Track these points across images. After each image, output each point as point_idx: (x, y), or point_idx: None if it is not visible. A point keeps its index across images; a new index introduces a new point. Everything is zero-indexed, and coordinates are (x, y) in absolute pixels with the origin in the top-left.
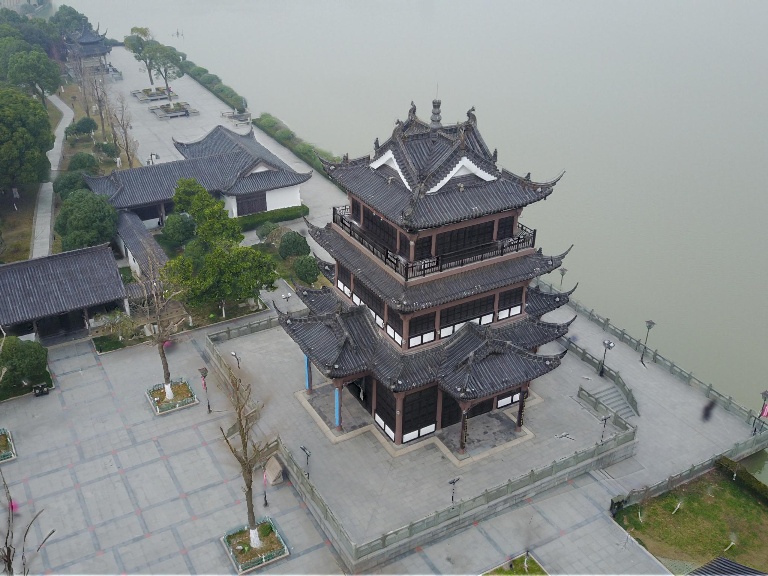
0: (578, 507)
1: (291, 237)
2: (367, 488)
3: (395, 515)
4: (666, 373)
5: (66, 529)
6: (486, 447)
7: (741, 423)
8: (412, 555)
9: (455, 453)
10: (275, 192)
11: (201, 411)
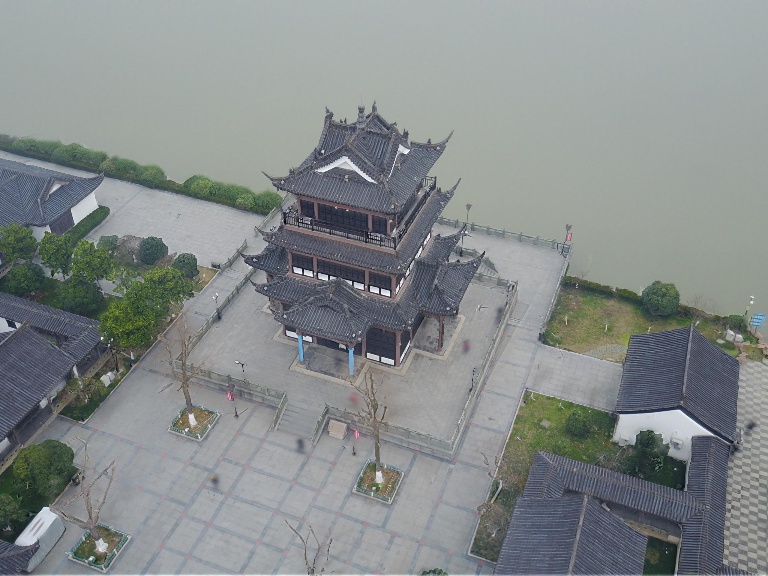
0: (522, 348)
1: (152, 243)
2: (409, 405)
3: (443, 411)
4: (486, 236)
5: (242, 555)
6: (448, 339)
7: (550, 250)
8: (470, 429)
9: (436, 353)
10: (79, 205)
11: (229, 420)
